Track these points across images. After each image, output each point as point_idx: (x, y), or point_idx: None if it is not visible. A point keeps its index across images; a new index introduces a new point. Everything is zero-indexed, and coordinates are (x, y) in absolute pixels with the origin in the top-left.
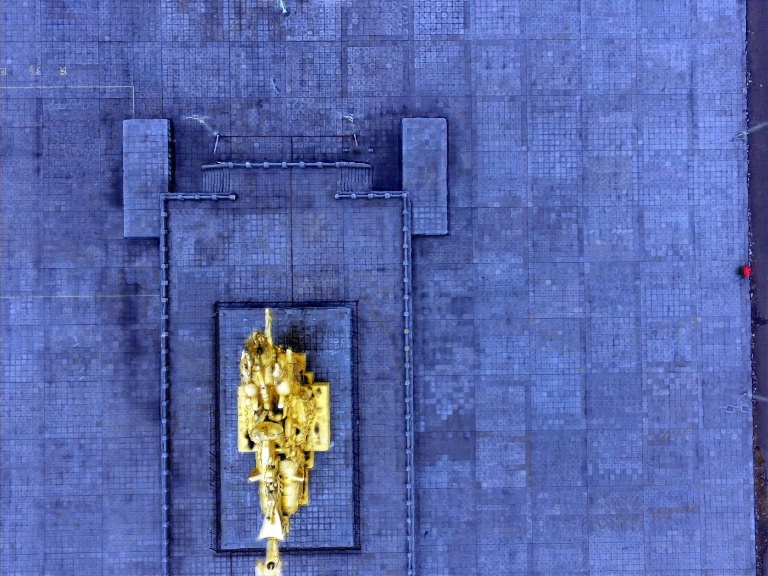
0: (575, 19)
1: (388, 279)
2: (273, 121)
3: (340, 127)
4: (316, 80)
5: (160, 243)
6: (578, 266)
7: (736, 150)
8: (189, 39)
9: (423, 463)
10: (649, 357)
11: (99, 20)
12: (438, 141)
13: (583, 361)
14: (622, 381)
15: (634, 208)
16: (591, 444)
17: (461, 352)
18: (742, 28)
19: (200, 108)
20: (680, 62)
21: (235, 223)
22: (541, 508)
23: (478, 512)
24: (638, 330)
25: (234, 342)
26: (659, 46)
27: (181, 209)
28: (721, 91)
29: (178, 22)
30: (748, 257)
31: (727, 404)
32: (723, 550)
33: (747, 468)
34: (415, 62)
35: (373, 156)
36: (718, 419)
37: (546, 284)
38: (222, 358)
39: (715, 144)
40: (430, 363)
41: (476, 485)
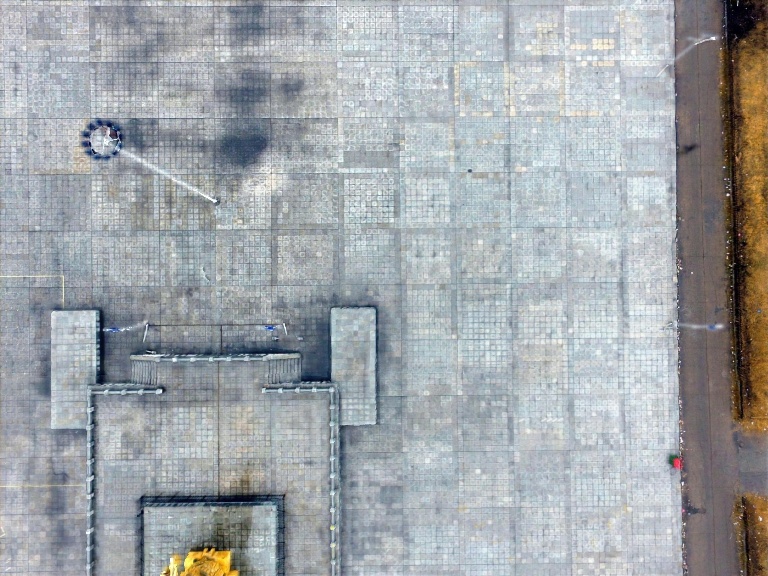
0: (505, 207)
1: (315, 472)
2: (203, 310)
3: (270, 315)
4: (246, 269)
5: (87, 437)
6: (508, 455)
7: (666, 339)
8: (119, 228)
9: None
10: (579, 547)
11: (30, 210)
12: (367, 332)
13: (513, 551)
14: (552, 571)
15: (564, 396)
16: None
17: (390, 542)
18: (672, 217)
19: (130, 297)
20: (610, 251)
21: (162, 416)
22: None
23: None
24: (568, 520)
25: (159, 540)
26: (589, 235)
27: (108, 402)
28: (651, 280)
29: (108, 211)
30: (679, 446)
31: None
32: None
33: None
34: (345, 251)
35: (303, 344)
36: None
37: (476, 473)
38: (146, 556)
39: (645, 333)
40: (359, 553)
41: None
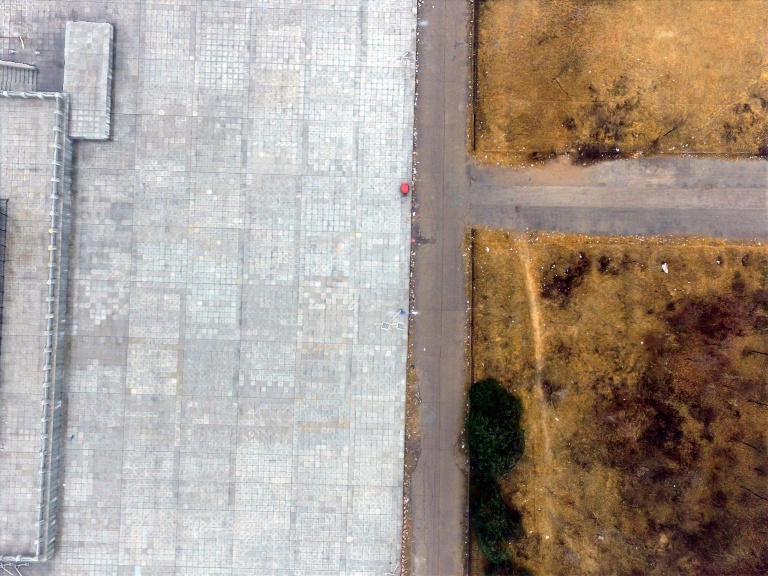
0: None
1: (40, 179)
2: None
3: (7, 28)
4: None
5: None
6: (240, 177)
7: (403, 69)
8: None
9: (73, 367)
10: (307, 271)
11: None
12: (100, 45)
13: (240, 272)
14: (278, 293)
15: (299, 122)
16: (244, 355)
17: (118, 257)
18: None
19: None
20: None
21: None
22: (190, 417)
23: (126, 418)
24: (297, 243)
25: None
26: None
27: None
28: (391, 10)
29: None
30: (412, 176)
31: (383, 321)
32: (371, 467)
33: (399, 386)
34: None
35: (39, 59)
36: (373, 335)
37: (207, 194)
38: None
39: (382, 62)
40: (86, 267)
41: (126, 391)
